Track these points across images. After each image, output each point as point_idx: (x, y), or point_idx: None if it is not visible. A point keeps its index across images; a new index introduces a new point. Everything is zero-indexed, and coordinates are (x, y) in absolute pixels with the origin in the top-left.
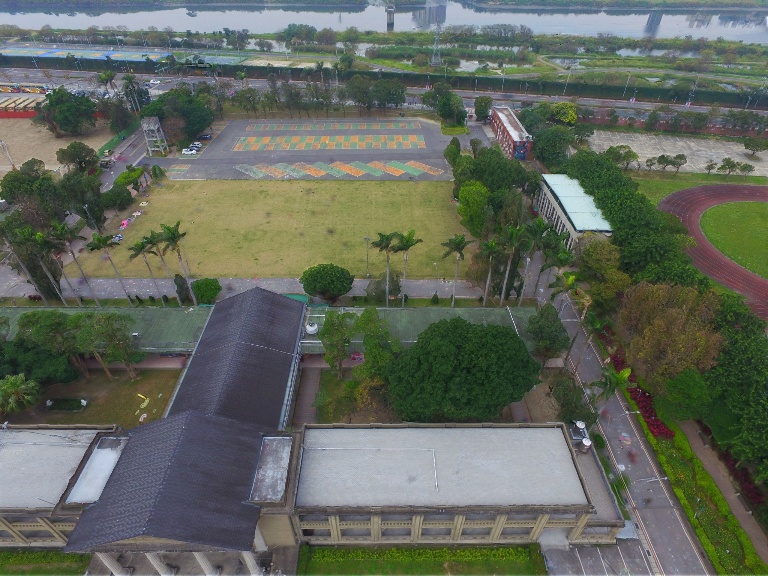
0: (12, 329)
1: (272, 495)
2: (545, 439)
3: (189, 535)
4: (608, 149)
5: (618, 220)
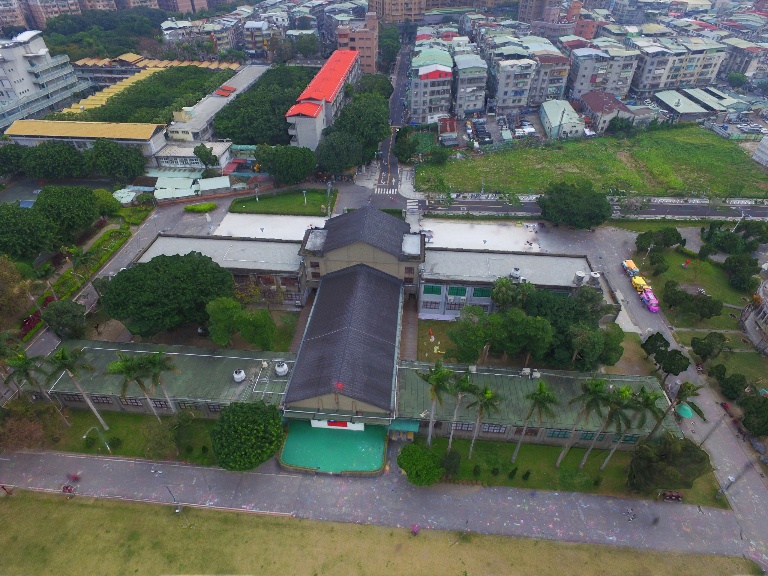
0: None
1: None
2: None
3: None
4: None
5: None
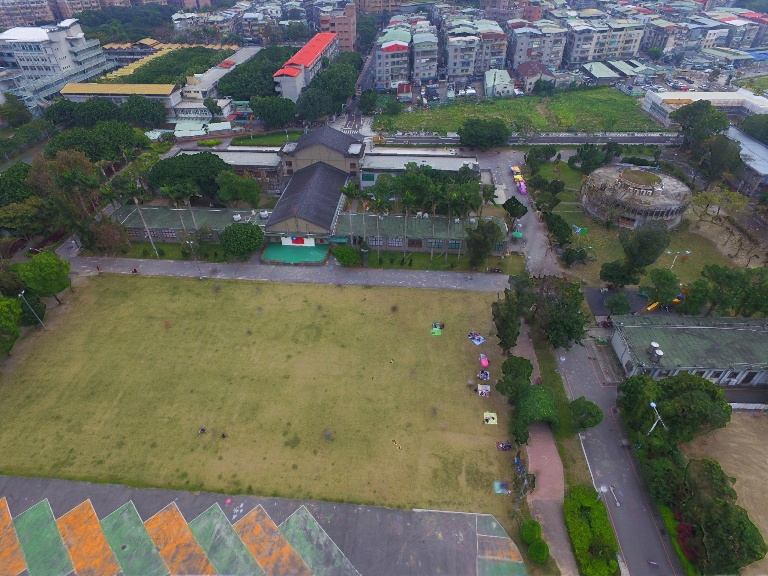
0: (470, 227)
1: None
2: None
3: None
4: None
5: None
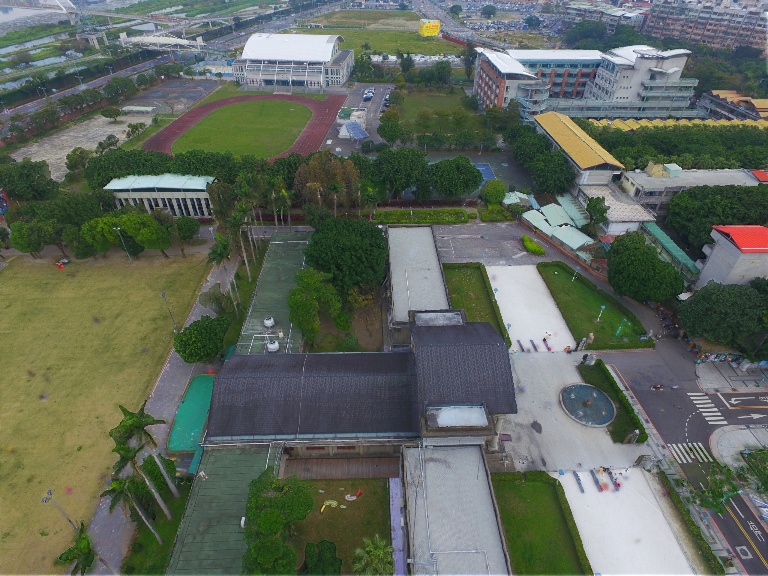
0: None
1: (455, 319)
2: (395, 233)
3: (496, 334)
4: (69, 158)
5: (211, 169)
